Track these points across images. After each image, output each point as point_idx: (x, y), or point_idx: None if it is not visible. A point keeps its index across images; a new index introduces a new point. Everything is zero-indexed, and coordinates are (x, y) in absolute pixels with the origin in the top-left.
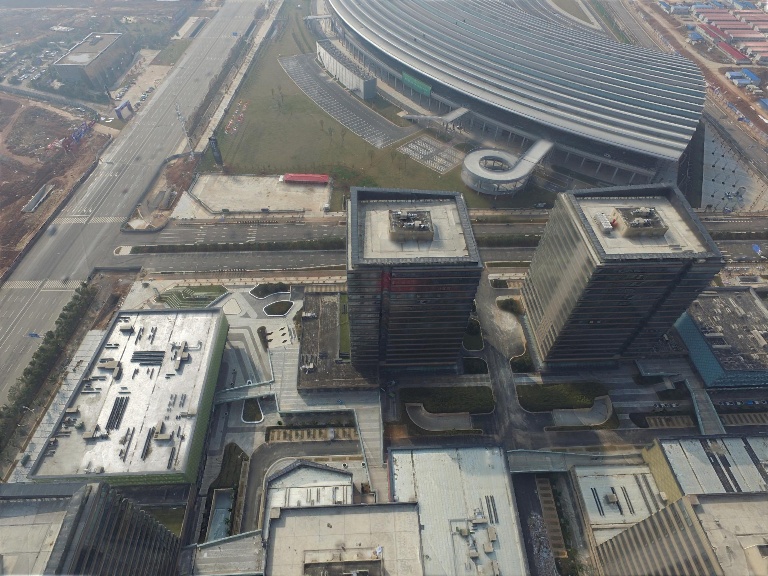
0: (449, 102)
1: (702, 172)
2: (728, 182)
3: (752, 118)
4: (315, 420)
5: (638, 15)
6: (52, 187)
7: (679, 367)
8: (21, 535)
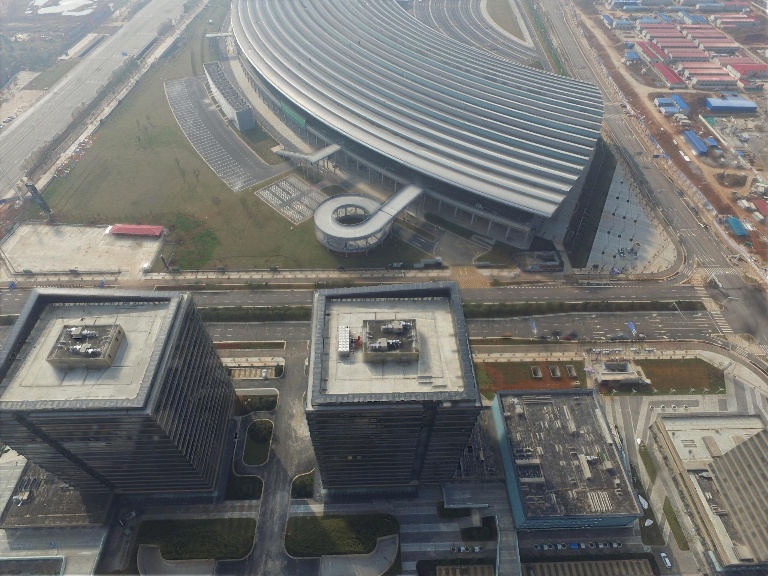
0: (323, 137)
1: (598, 222)
2: (625, 235)
3: (672, 154)
4: (9, 573)
5: (578, 30)
6: None
7: (493, 495)
8: None
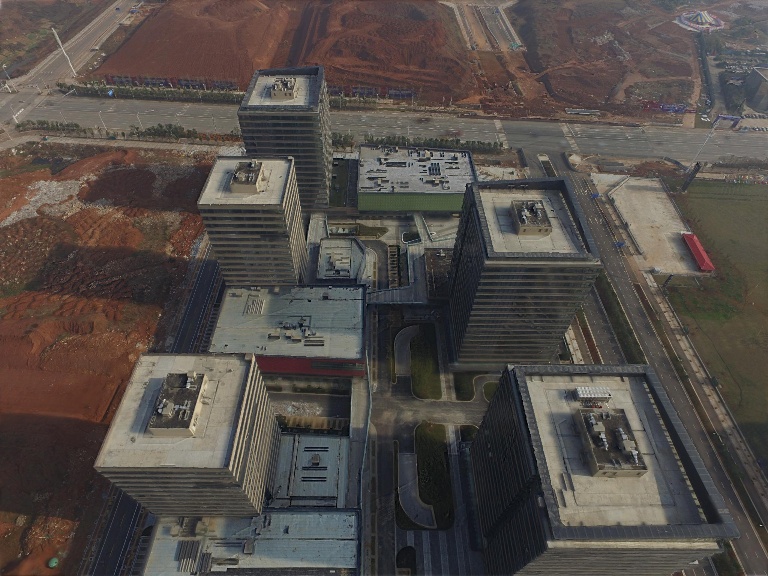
0: None
1: None
2: None
3: None
4: None
5: None
6: (597, 114)
7: None
8: (301, 101)
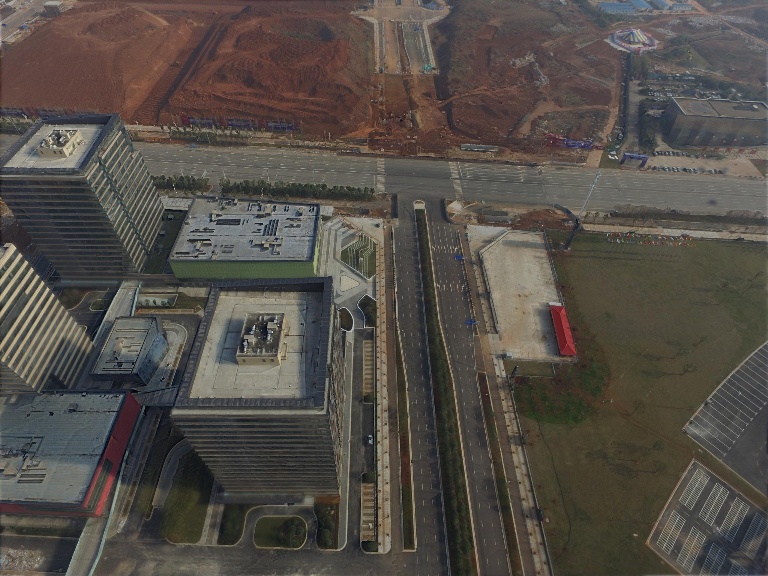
0: None
1: None
2: None
3: None
4: None
5: None
6: (495, 150)
7: None
8: (74, 160)
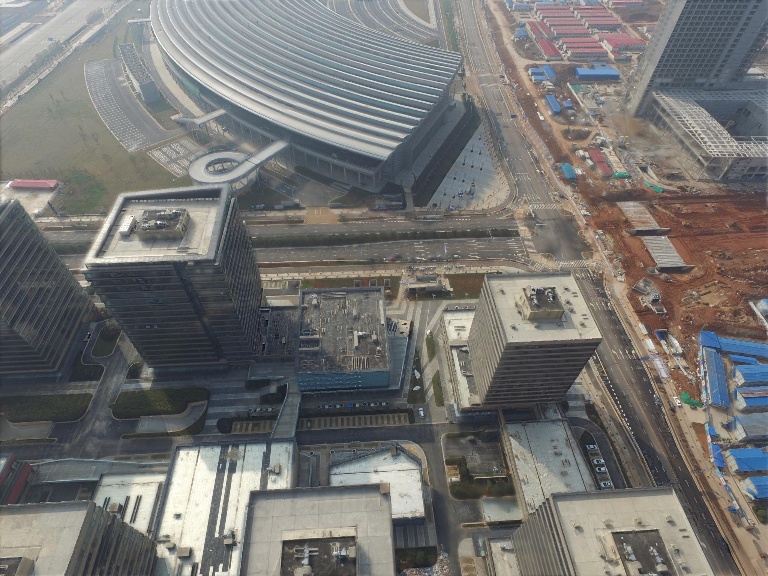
0: (213, 104)
1: (448, 170)
2: (469, 180)
3: (531, 115)
4: None
5: (481, 13)
6: None
7: (291, 370)
8: None
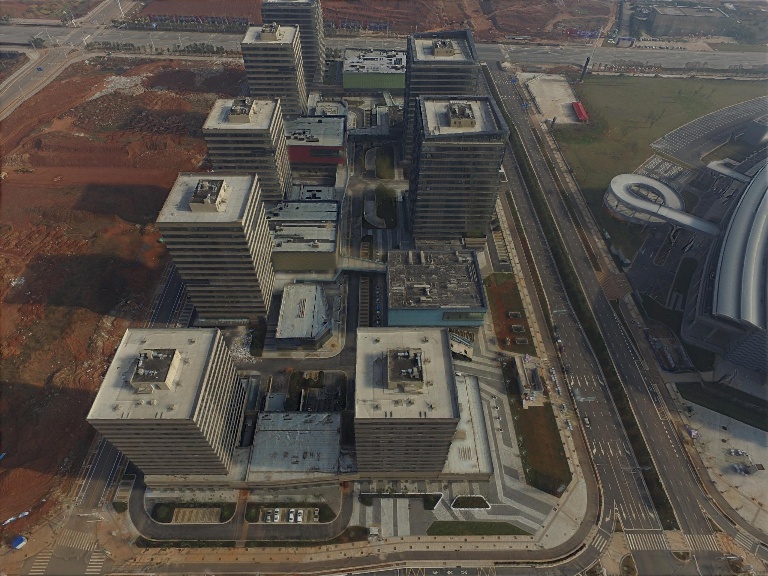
0: None
1: None
2: None
3: None
4: None
5: None
6: (529, 39)
7: None
8: (303, 1)
